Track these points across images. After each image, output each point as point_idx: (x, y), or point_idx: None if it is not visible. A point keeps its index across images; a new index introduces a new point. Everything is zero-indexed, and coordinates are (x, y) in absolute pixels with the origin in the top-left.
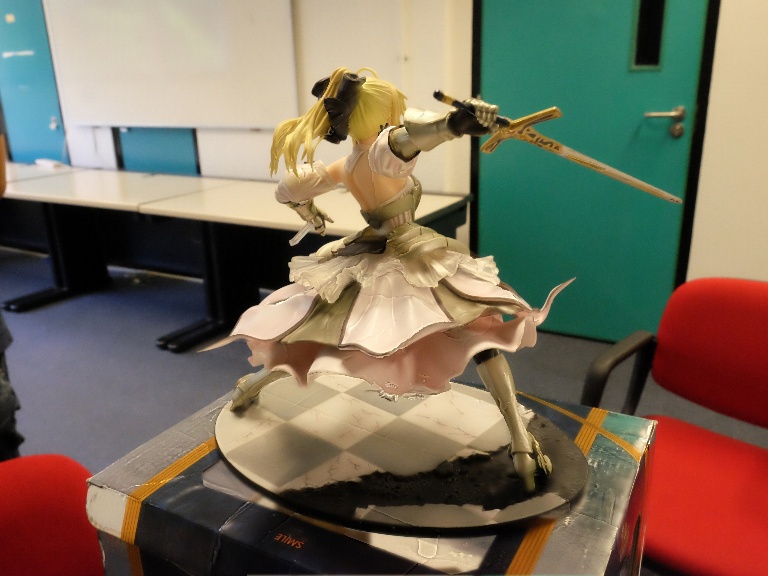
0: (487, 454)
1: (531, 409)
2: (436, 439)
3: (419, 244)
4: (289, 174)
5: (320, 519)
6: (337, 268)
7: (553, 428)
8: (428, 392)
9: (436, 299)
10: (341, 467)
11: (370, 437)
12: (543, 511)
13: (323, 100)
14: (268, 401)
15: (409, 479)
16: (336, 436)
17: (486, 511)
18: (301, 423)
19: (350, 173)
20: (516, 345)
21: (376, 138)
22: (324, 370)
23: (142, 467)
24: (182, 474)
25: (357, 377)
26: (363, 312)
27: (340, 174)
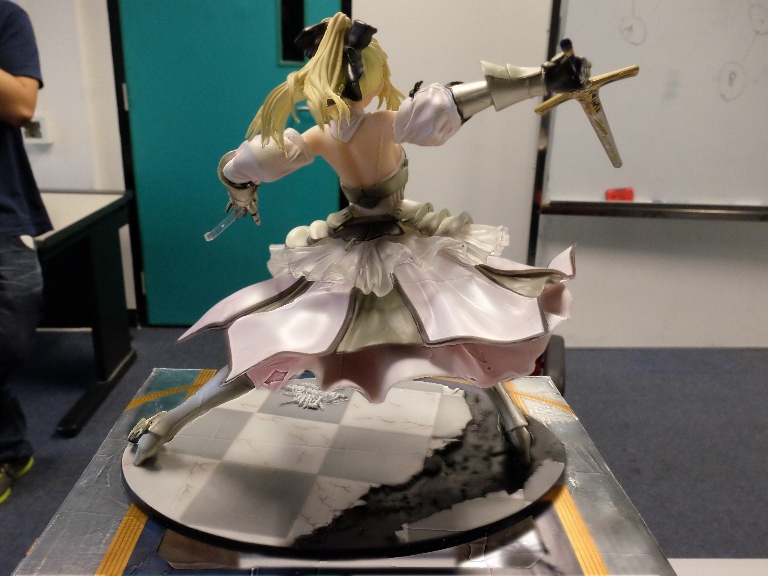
0: (458, 440)
1: (452, 388)
2: (397, 438)
3: (450, 219)
4: (258, 146)
5: (355, 559)
6: (355, 256)
7: (487, 401)
8: (509, 378)
9: (488, 277)
10: (331, 494)
11: (330, 453)
12: (557, 479)
13: (330, 51)
14: (175, 443)
15: (408, 486)
16: (293, 462)
17: (512, 494)
18: (240, 458)
19: (346, 142)
20: (567, 314)
21: (365, 102)
22: (420, 375)
23: (63, 574)
24: (132, 564)
25: (456, 375)
26: (425, 301)
27: (325, 145)
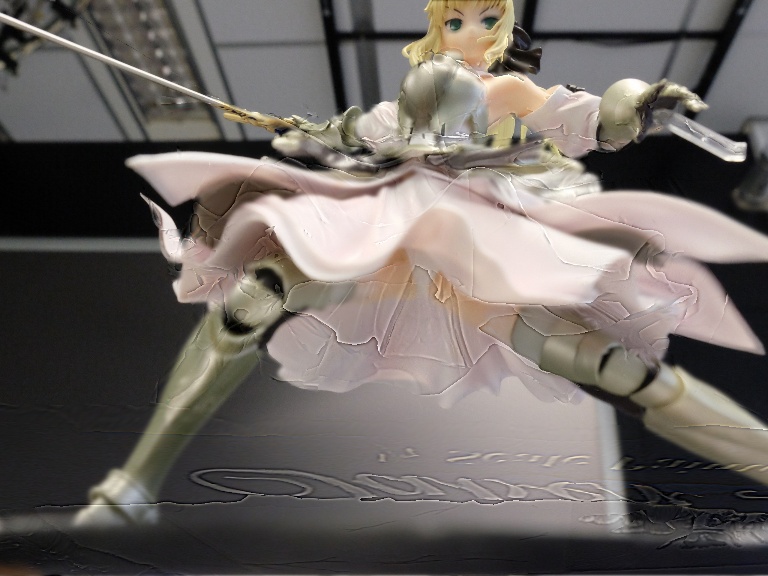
0: None
1: None
2: None
3: None
4: None
5: None
6: None
7: None
8: None
9: None
10: None
11: None
12: None
13: None
14: None
15: None
16: None
17: None
18: None
19: None
20: (190, 300)
21: None
22: (388, 384)
23: None
24: None
25: None
26: (381, 309)
27: None
